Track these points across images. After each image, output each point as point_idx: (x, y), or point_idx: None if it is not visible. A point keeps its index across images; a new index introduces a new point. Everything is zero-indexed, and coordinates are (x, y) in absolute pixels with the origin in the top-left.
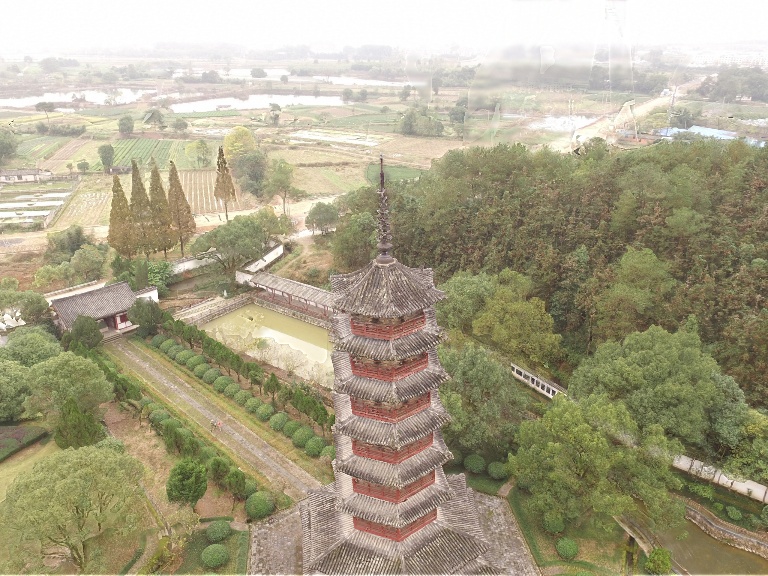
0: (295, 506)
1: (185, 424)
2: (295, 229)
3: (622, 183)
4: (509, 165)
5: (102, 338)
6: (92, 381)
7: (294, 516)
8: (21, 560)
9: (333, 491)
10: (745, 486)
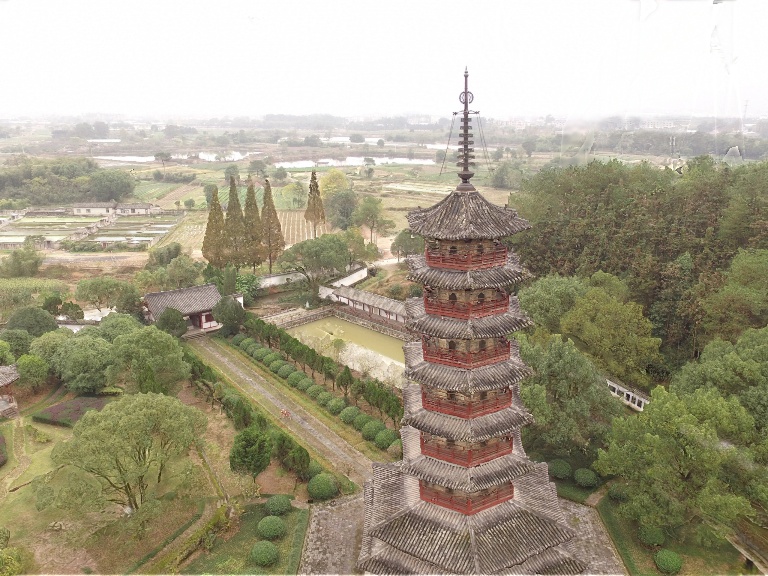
0: (360, 492)
1: (256, 410)
2: (380, 254)
3: (731, 191)
4: (604, 179)
5: (186, 331)
6: (171, 355)
7: (358, 501)
8: (78, 488)
9: (400, 465)
10: None
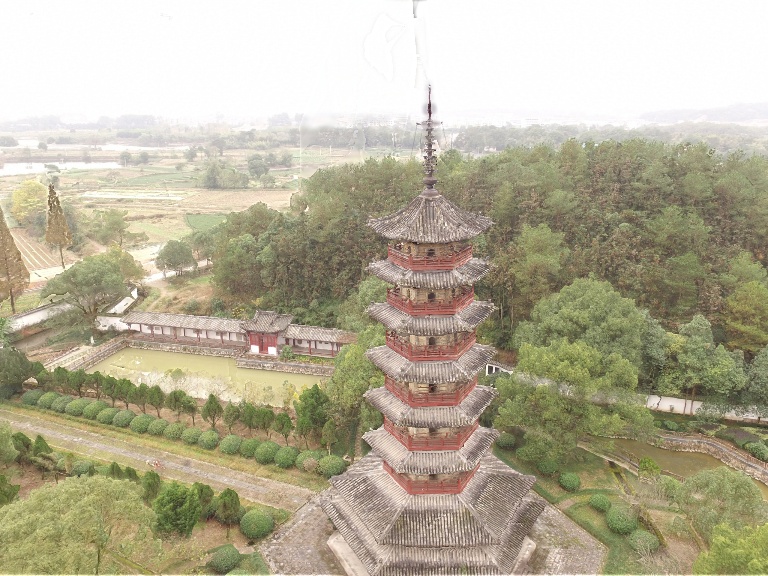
0: (294, 516)
1: None
2: (146, 271)
3: (495, 179)
4: (387, 174)
5: None
6: None
7: (299, 526)
8: None
9: None
10: (668, 404)
